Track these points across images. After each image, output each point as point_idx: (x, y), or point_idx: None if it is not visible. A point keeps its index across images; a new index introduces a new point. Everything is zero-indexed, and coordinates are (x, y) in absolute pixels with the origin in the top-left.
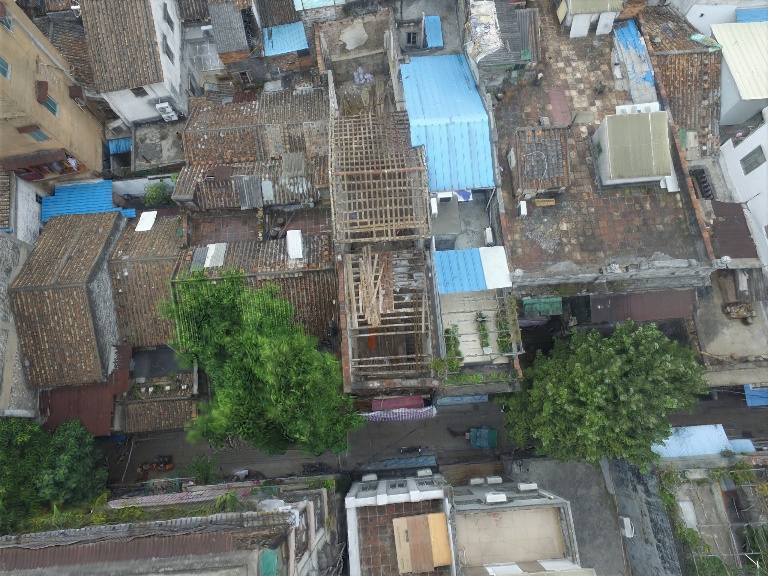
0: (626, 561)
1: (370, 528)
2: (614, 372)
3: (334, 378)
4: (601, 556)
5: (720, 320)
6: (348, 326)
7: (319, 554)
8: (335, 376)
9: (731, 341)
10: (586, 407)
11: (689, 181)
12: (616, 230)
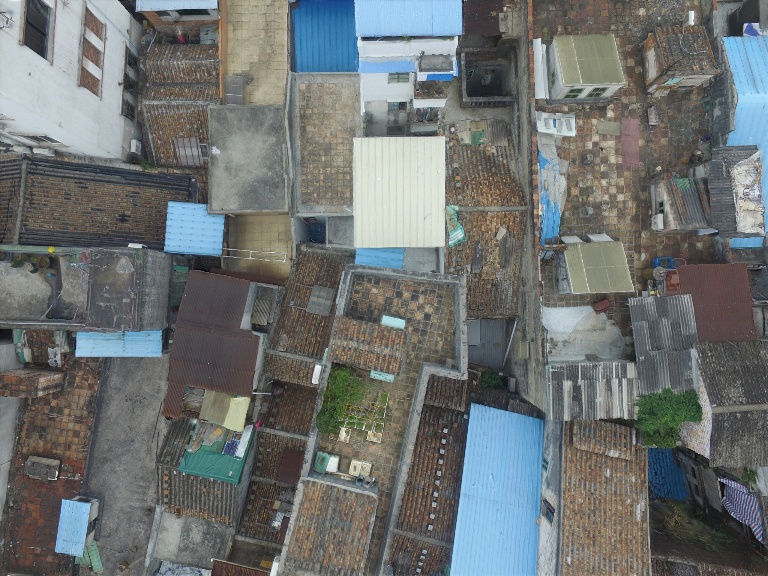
0: None
1: None
2: None
3: None
4: None
5: None
6: None
7: None
8: None
9: None
10: None
11: (532, 36)
12: (593, 7)
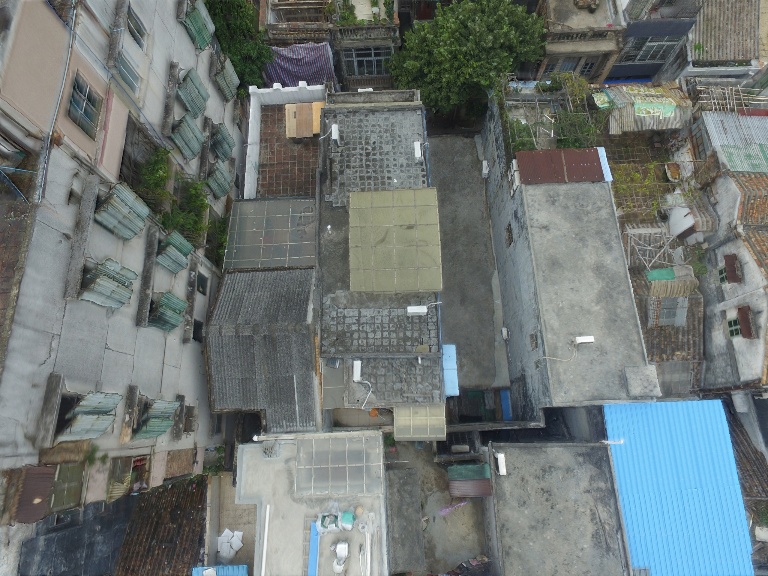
0: (486, 204)
1: (270, 120)
2: (467, 10)
3: (251, 15)
4: (467, 200)
5: (571, 10)
6: (270, 1)
7: (212, 54)
8: (252, 15)
9: (577, 23)
10: (442, 34)
11: None
12: None
